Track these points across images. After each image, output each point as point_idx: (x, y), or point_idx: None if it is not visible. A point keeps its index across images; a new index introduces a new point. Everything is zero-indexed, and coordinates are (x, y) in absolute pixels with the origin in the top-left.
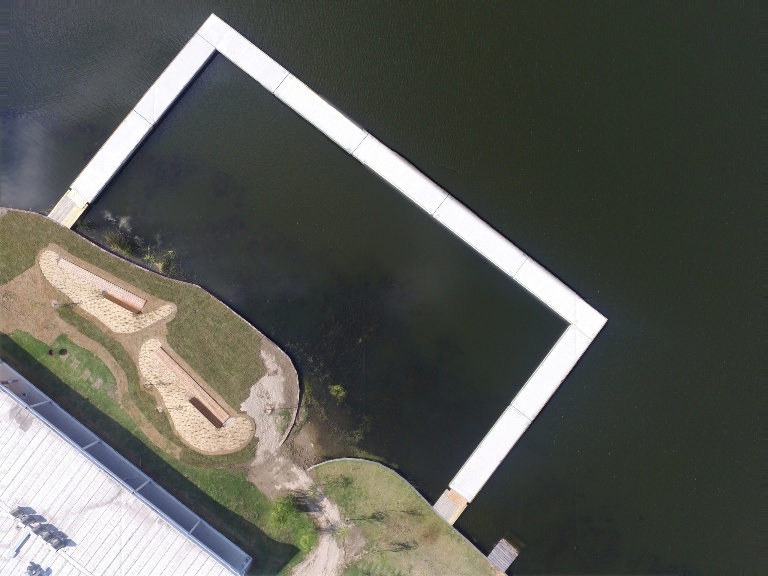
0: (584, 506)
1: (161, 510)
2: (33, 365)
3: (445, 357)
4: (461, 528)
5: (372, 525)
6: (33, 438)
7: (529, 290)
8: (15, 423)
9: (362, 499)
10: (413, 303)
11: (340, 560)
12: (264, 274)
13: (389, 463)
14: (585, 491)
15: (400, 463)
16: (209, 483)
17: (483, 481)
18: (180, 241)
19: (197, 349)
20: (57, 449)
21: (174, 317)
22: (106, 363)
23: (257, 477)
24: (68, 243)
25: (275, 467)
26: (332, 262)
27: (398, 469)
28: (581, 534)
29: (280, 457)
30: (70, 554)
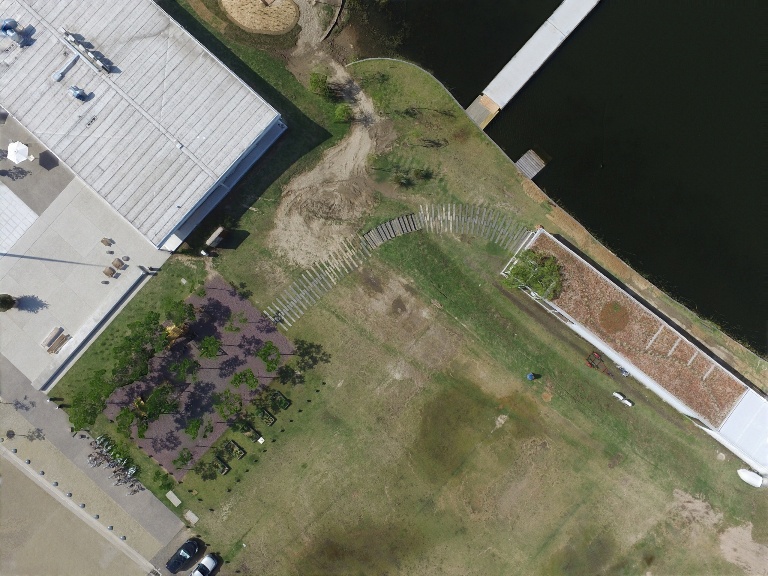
0: (612, 128)
1: (206, 48)
2: None
3: None
4: (491, 136)
5: (405, 120)
6: None
7: None
8: None
9: (397, 95)
10: None
11: (371, 150)
12: None
13: (425, 69)
14: (614, 113)
15: (436, 70)
16: (250, 59)
17: (516, 89)
18: None
19: None
20: None
21: None
22: None
23: (296, 68)
24: None
25: (314, 60)
26: None
27: (433, 75)
28: (607, 153)
29: (320, 52)
30: (114, 80)
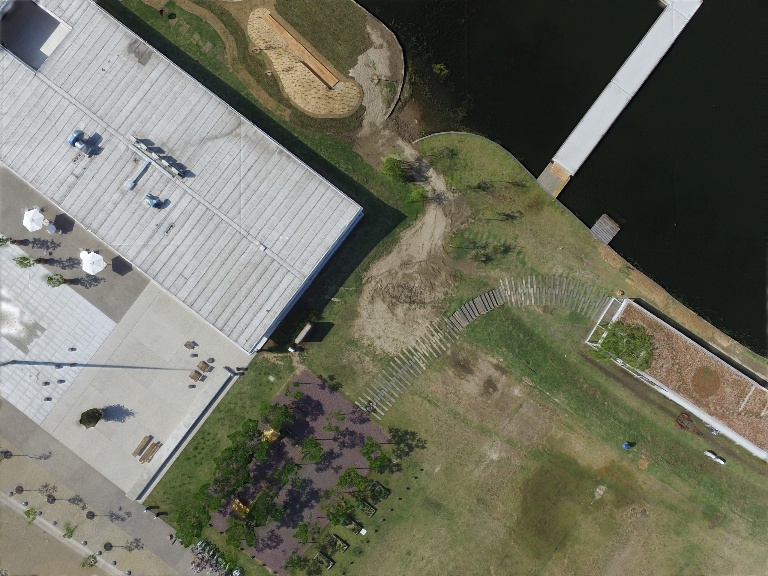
0: (682, 185)
1: (280, 144)
2: (143, 26)
3: (545, 39)
4: (564, 203)
5: (478, 195)
6: (152, 72)
7: None
8: (134, 57)
9: (468, 170)
10: None
11: (447, 228)
12: None
13: (492, 139)
14: (683, 170)
15: (503, 139)
16: (318, 145)
17: (585, 154)
18: None
19: (305, 18)
20: (176, 82)
21: None
22: (215, 28)
23: (363, 148)
24: None
25: (381, 139)
26: None
27: (501, 145)
28: (680, 211)
29: (386, 130)
30: (189, 185)
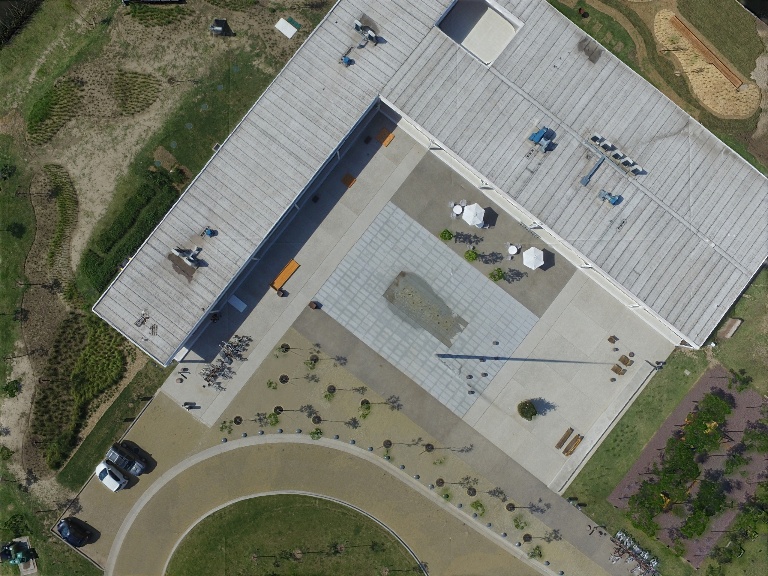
0: None
1: None
2: None
3: None
4: None
5: None
6: (602, 70)
7: None
8: (584, 55)
9: None
10: None
11: None
12: None
13: None
14: None
15: None
16: None
17: None
18: None
19: (706, 21)
20: (626, 80)
21: None
22: (626, 28)
23: (756, 149)
24: None
25: None
26: None
27: None
28: None
29: None
30: (641, 182)
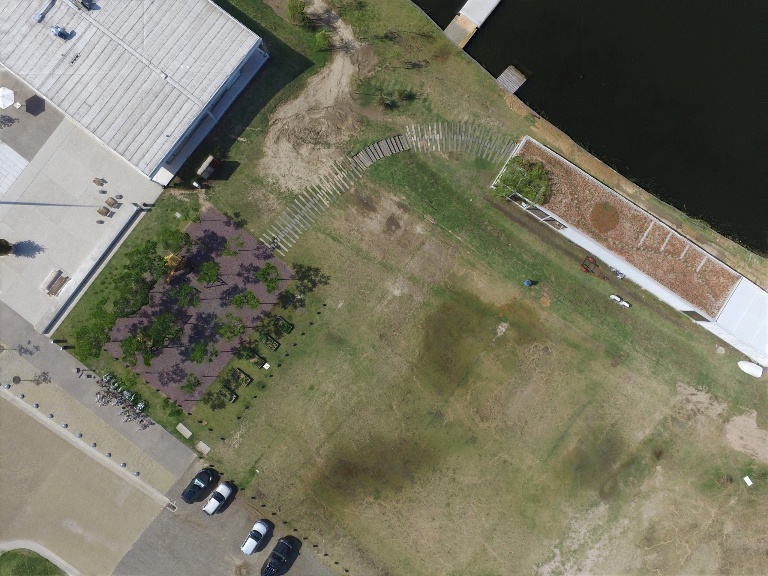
0: (589, 39)
1: None
2: None
3: None
4: (471, 55)
5: (385, 44)
6: None
7: None
8: None
9: (375, 21)
10: None
11: (354, 76)
12: None
13: None
14: (589, 24)
15: None
16: None
17: (491, 7)
18: None
19: None
20: None
21: None
22: None
23: (274, 1)
24: None
25: None
26: None
27: None
28: (586, 63)
29: None
30: (94, 17)
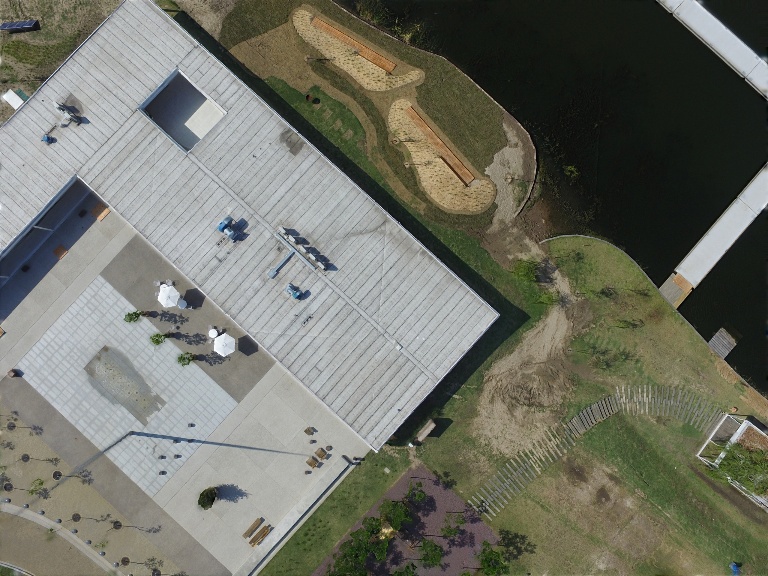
0: None
1: None
2: (288, 109)
3: (675, 150)
4: (682, 314)
5: (601, 300)
6: (302, 162)
7: (759, 92)
8: (285, 146)
9: (592, 275)
10: (647, 95)
11: (568, 331)
12: (506, 55)
13: (617, 245)
14: None
15: (627, 246)
16: (450, 240)
17: (708, 268)
18: (429, 15)
19: (445, 113)
20: (326, 174)
21: (423, 82)
22: (357, 116)
23: (491, 245)
24: (321, 6)
25: (509, 237)
26: (573, 49)
27: (625, 251)
28: None
29: (514, 228)
30: (330, 278)
